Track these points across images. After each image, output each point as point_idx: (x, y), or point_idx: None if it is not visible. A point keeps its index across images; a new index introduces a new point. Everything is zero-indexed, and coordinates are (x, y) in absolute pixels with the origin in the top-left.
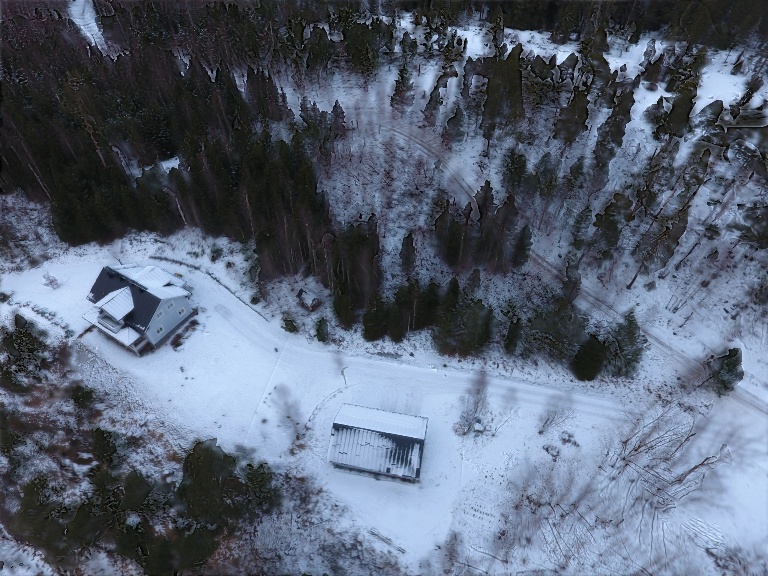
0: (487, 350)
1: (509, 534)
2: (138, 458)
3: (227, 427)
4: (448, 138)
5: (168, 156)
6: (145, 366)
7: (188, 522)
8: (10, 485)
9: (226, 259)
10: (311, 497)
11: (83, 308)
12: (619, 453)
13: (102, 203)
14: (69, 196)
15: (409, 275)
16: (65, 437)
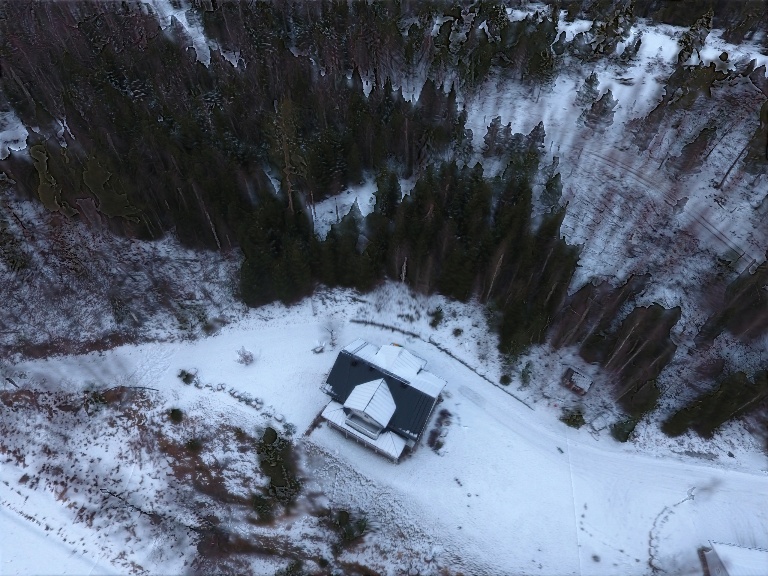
0: None
1: None
2: None
3: (550, 567)
4: (682, 168)
5: (340, 190)
6: (409, 477)
7: None
8: None
9: (450, 324)
10: None
11: (293, 392)
12: None
13: (301, 259)
14: (256, 250)
15: (689, 346)
16: (319, 570)
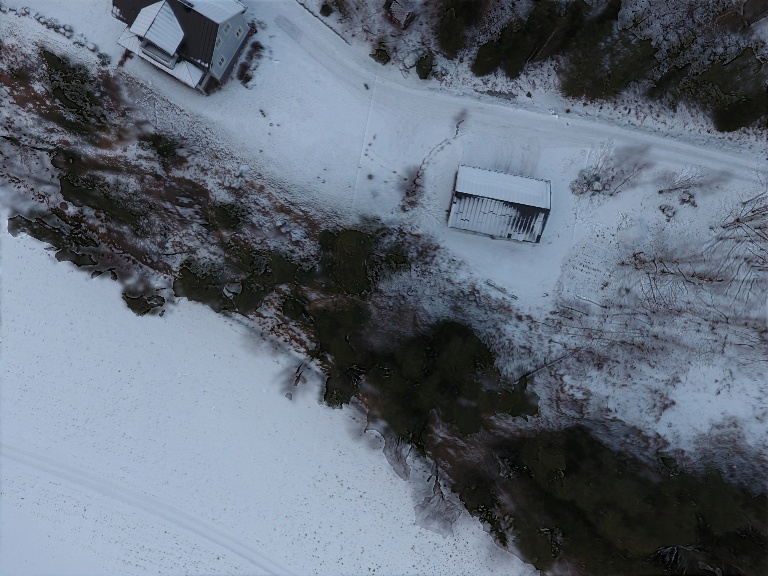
0: (621, 91)
1: (611, 286)
2: (244, 208)
3: (332, 182)
4: None
5: None
6: (217, 108)
7: (312, 266)
8: (122, 224)
9: None
10: (428, 252)
11: (102, 19)
12: (735, 214)
13: None
14: None
15: None
16: (157, 182)
